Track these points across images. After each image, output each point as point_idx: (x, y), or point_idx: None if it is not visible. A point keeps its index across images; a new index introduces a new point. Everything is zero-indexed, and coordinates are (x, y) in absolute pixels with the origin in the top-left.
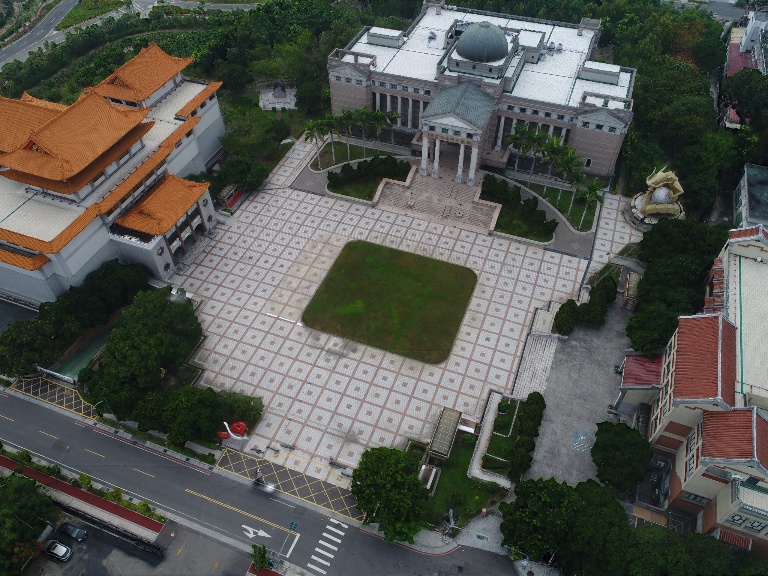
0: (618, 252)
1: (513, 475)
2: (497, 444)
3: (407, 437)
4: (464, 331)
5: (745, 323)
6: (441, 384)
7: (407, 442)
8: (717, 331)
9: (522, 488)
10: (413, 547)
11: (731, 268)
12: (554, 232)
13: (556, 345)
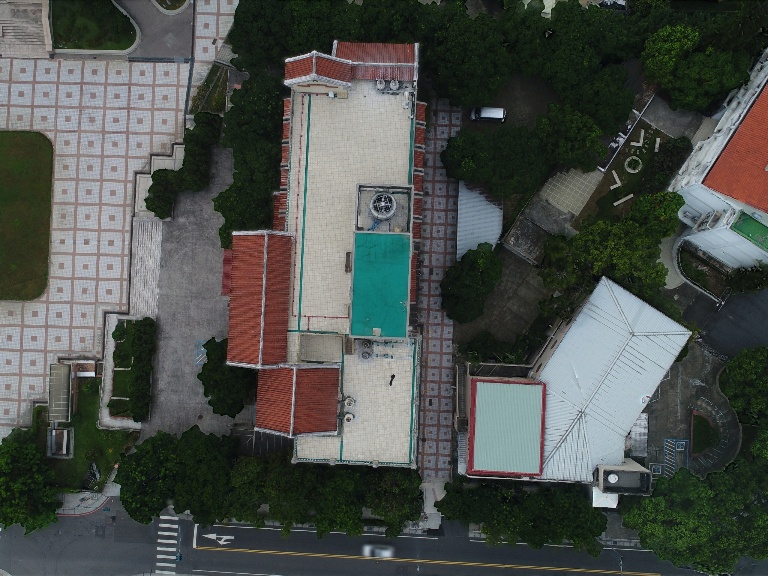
0: (226, 35)
1: (137, 420)
2: (121, 381)
3: (31, 400)
4: (56, 239)
5: (308, 219)
6: (49, 323)
7: (33, 406)
8: (263, 261)
9: (122, 467)
10: (67, 513)
11: (297, 122)
12: (137, 23)
13: (161, 231)
